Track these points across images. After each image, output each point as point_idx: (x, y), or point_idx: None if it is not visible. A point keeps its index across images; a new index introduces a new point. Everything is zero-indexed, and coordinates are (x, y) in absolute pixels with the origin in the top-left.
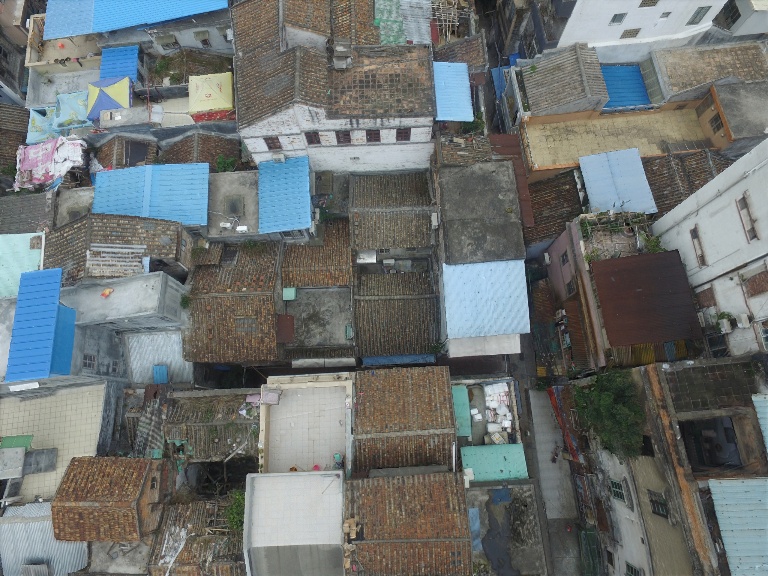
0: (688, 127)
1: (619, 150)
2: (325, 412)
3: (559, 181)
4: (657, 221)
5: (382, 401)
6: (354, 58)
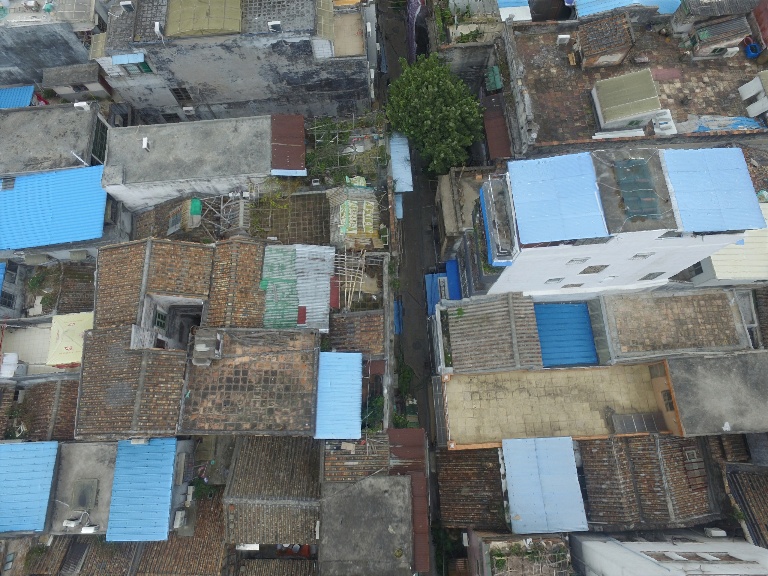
0: (638, 390)
1: (549, 437)
2: None
3: (482, 454)
4: (586, 545)
5: None
6: (225, 345)
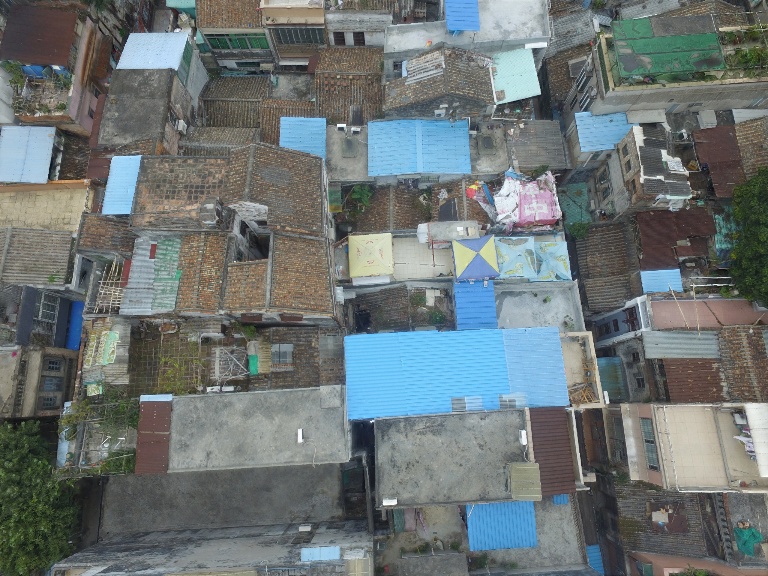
0: None
1: None
2: (285, 2)
3: None
4: (6, 118)
5: (244, 2)
6: None
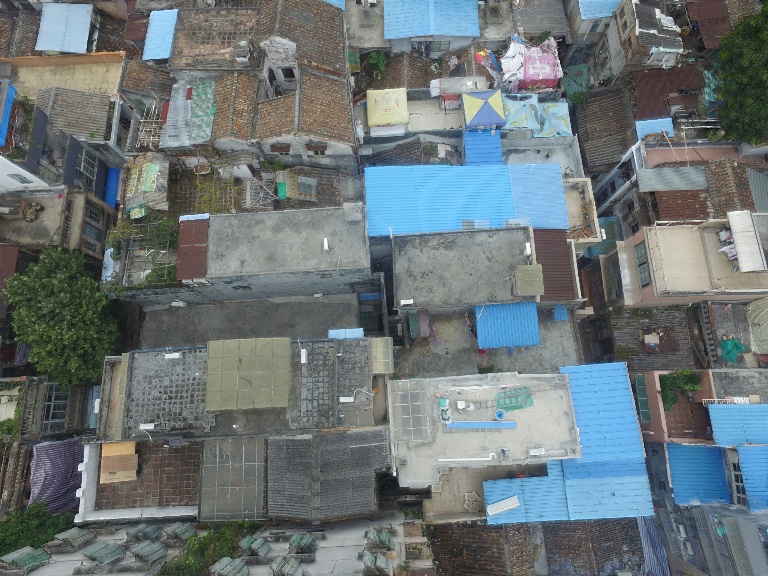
0: None
1: None
2: None
3: None
4: None
5: None
6: None
